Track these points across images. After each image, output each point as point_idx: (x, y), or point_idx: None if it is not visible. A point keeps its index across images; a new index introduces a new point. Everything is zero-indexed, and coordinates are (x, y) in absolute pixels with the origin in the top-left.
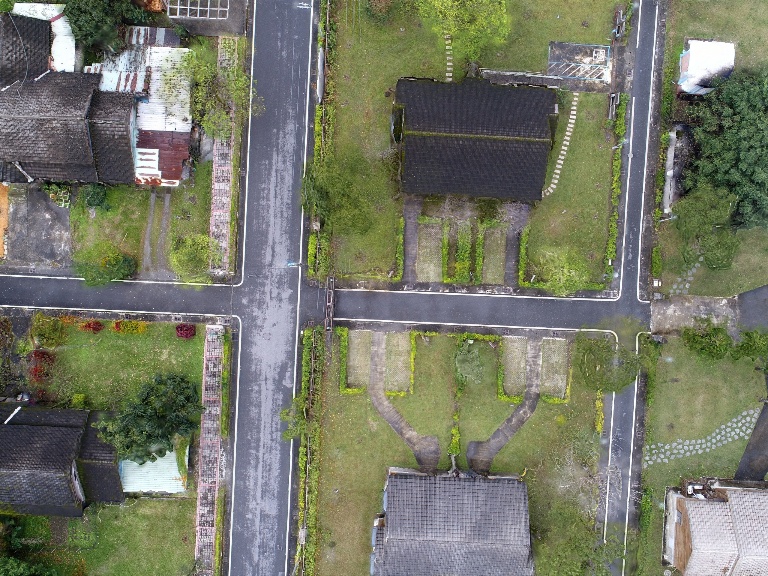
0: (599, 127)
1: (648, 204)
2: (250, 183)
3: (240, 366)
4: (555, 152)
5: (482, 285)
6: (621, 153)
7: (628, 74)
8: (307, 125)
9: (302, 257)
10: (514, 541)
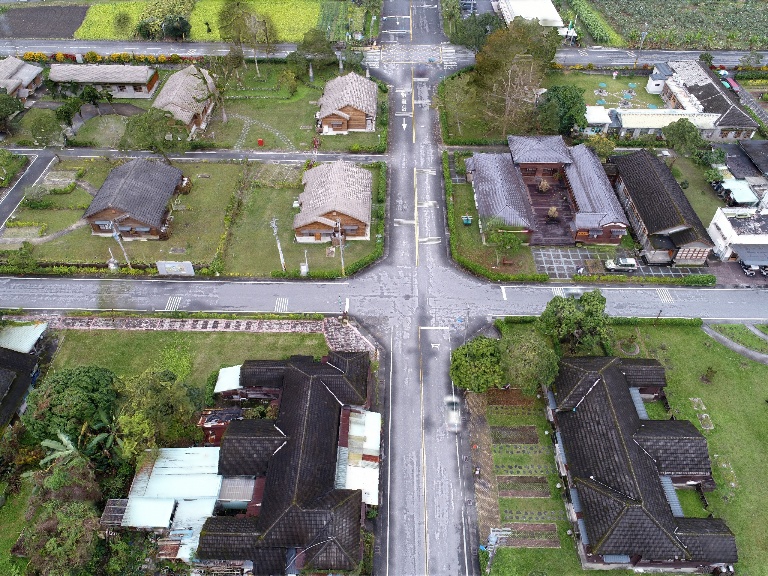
0: None
1: None
2: None
3: None
4: None
5: None
6: None
7: None
8: None
9: None
10: None
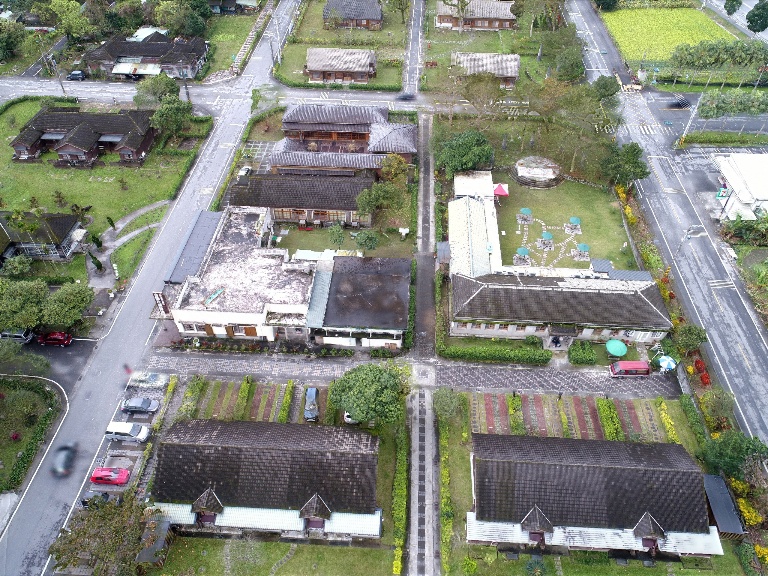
0: None
1: None
2: None
3: None
4: None
5: None
6: None
7: None
8: None
9: None
10: None
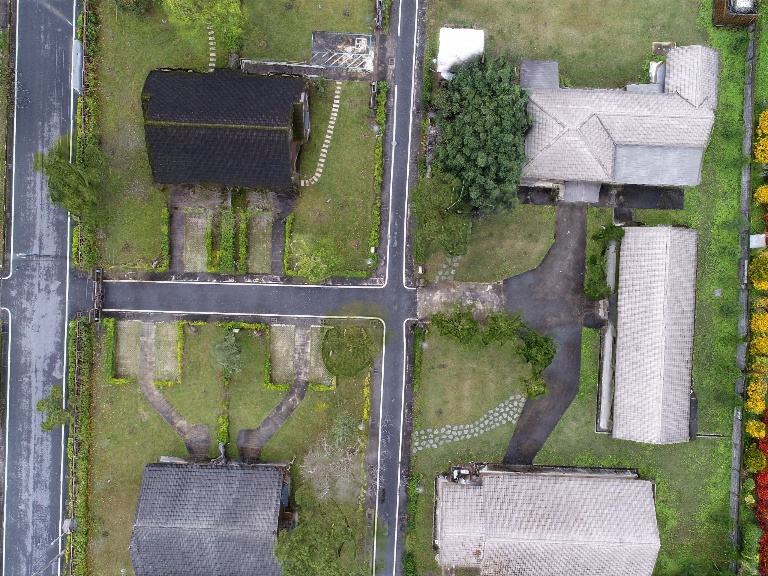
0: (362, 115)
1: (412, 191)
2: (17, 176)
3: (10, 358)
4: (319, 141)
5: (249, 274)
6: (384, 141)
7: (390, 62)
8: (72, 117)
9: (70, 249)
10: (261, 527)
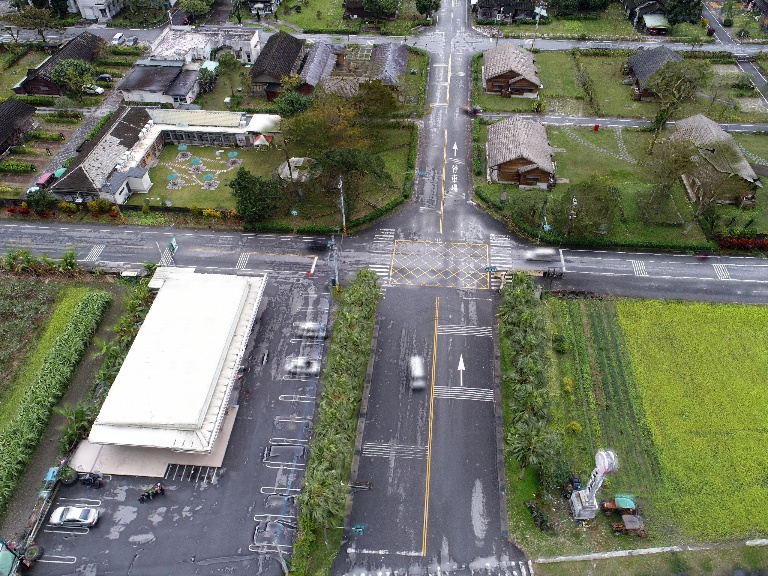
0: None
1: None
2: None
3: None
4: None
5: None
6: None
7: None
8: None
9: None
10: None
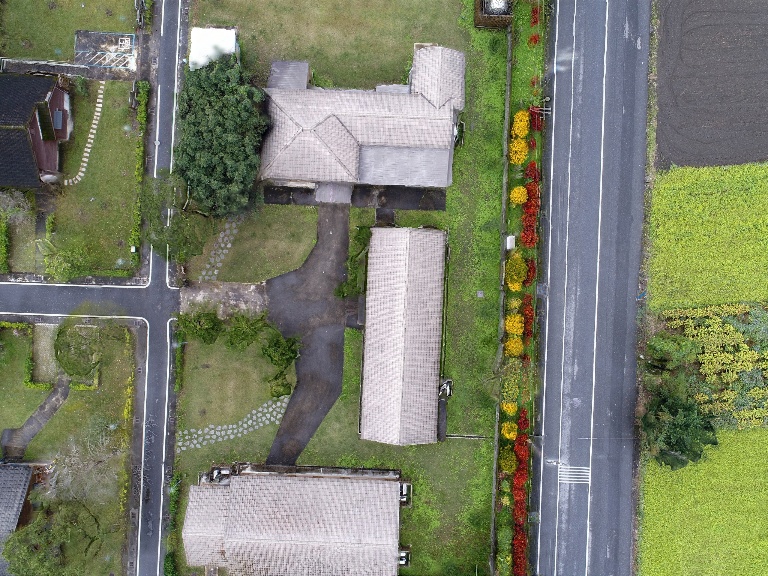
0: (125, 115)
1: None
2: None
3: None
4: (82, 140)
5: (13, 273)
6: (148, 141)
7: (153, 62)
8: None
9: None
10: (0, 526)
